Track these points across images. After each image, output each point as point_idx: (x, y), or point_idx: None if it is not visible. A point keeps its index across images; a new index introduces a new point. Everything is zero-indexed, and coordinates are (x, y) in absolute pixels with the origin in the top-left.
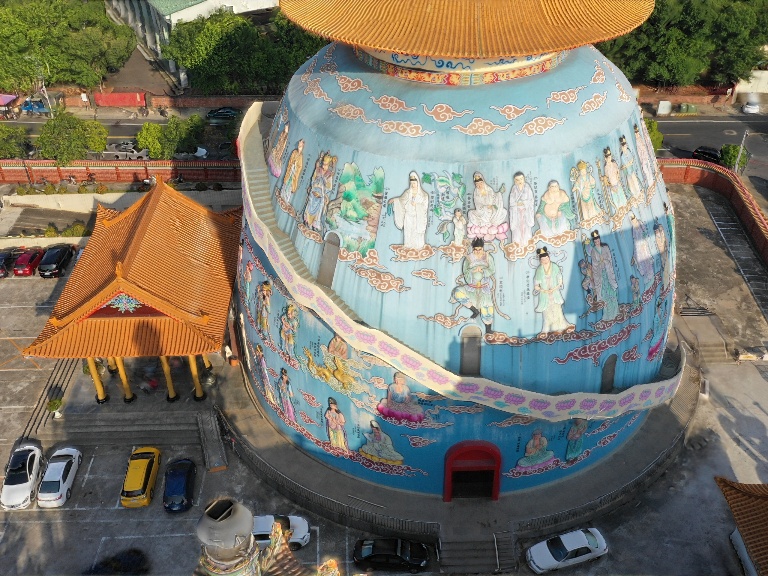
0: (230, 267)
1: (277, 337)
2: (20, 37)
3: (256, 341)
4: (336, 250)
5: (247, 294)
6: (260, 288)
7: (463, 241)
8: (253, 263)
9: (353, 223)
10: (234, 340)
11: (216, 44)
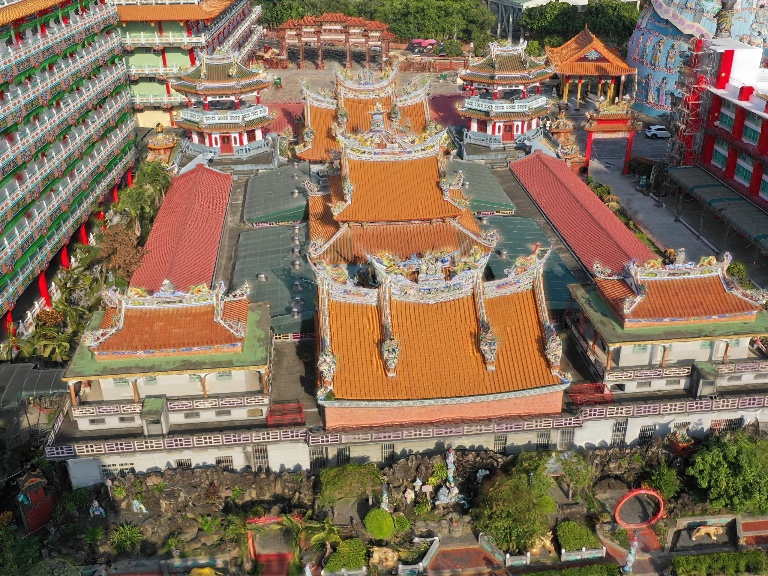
0: (622, 60)
1: (664, 62)
2: (451, 6)
3: (648, 73)
4: (702, 14)
5: (647, 52)
6: (657, 44)
7: (756, 6)
8: (653, 36)
9: (711, 2)
10: (622, 92)
11: (557, 13)
